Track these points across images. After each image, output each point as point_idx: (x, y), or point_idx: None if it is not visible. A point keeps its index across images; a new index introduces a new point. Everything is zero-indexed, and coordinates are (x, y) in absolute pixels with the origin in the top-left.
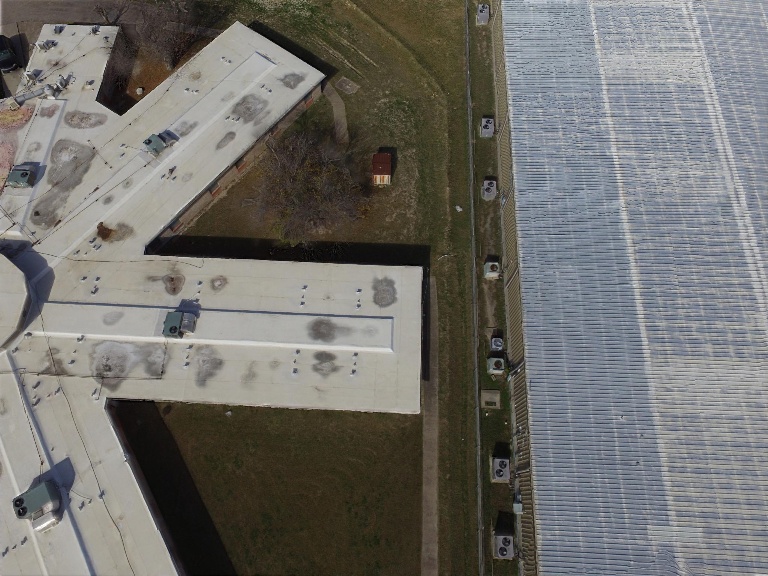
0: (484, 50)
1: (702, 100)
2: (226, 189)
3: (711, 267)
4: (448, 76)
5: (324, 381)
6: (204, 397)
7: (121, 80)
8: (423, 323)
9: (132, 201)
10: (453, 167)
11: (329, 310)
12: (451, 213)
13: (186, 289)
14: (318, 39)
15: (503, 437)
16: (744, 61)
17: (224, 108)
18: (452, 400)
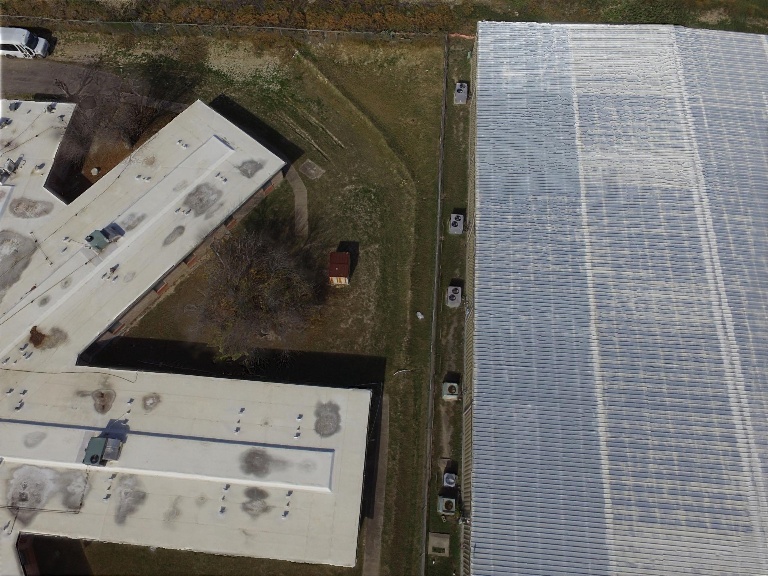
0: (460, 133)
1: (691, 209)
2: (174, 285)
3: (690, 414)
4: (420, 161)
5: (253, 523)
6: (122, 536)
7: (77, 159)
8: (371, 451)
9: (69, 303)
10: (417, 267)
11: (265, 438)
12: (411, 321)
13: (116, 407)
14: (285, 116)
15: None
16: (742, 161)
17: (175, 199)
18: (396, 543)
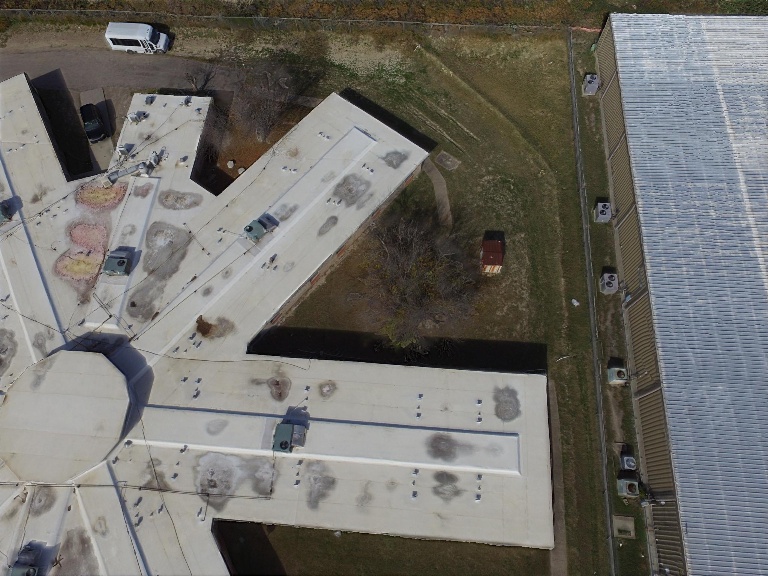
0: (593, 123)
1: None
2: (325, 275)
3: None
4: (555, 152)
5: (447, 507)
6: (317, 521)
7: (211, 152)
8: None
9: (232, 292)
10: (566, 255)
11: (448, 424)
12: (568, 308)
13: (293, 394)
14: (414, 108)
15: (640, 573)
16: None
17: (324, 189)
18: (581, 527)
